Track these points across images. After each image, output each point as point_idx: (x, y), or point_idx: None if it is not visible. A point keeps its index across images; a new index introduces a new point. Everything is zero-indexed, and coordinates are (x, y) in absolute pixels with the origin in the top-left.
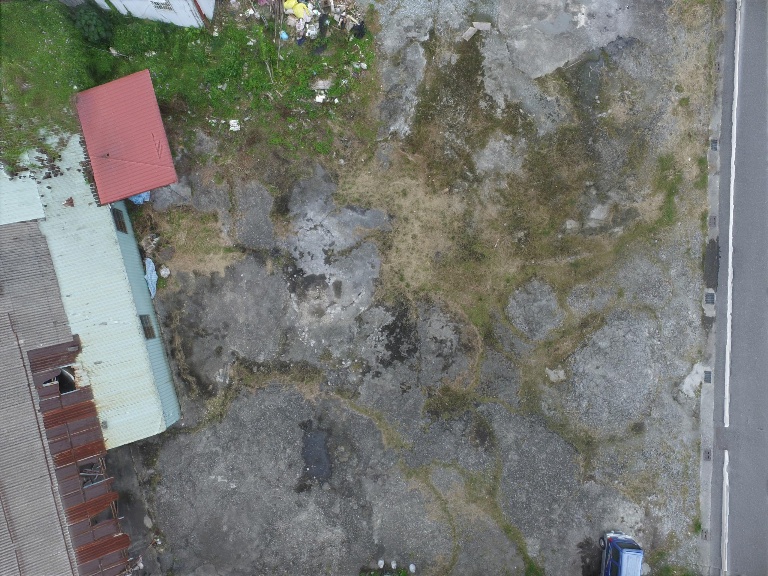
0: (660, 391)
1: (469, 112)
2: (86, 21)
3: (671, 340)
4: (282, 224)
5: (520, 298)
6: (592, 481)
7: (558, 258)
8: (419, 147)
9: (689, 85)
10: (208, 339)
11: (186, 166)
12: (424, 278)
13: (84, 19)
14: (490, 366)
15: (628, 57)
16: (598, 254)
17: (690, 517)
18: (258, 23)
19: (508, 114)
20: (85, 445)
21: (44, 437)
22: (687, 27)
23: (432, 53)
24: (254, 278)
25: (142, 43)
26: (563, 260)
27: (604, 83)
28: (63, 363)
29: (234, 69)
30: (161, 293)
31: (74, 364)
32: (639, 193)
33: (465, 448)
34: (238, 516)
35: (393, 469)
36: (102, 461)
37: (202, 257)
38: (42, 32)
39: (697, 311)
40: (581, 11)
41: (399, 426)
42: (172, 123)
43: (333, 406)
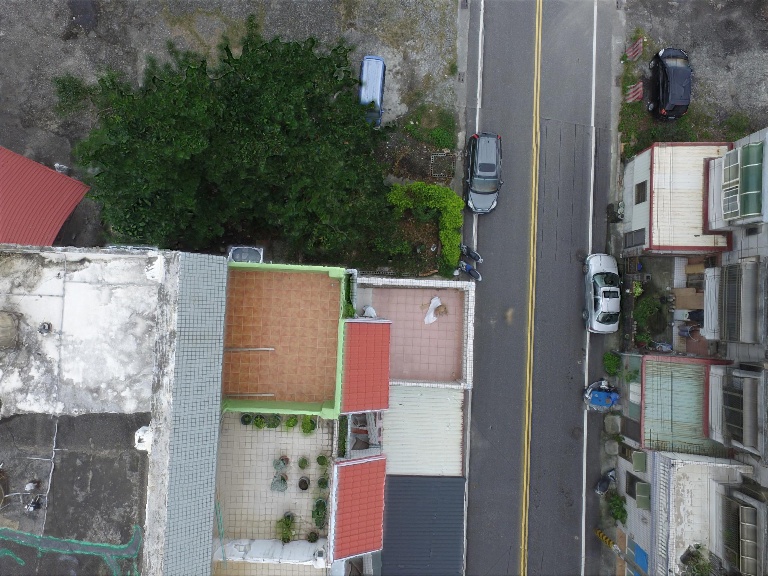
0: None
1: None
2: None
3: None
4: None
5: None
6: (352, 28)
7: None
8: None
9: None
10: None
11: None
12: None
13: None
14: None
15: None
16: None
17: (447, 61)
18: None
19: None
20: None
21: None
22: None
23: None
24: None
25: None
26: None
27: None
28: None
29: None
30: None
31: None
32: None
33: None
34: (6, 62)
35: (157, 18)
36: None
37: None
38: None
39: None
40: None
41: None
42: None
43: None
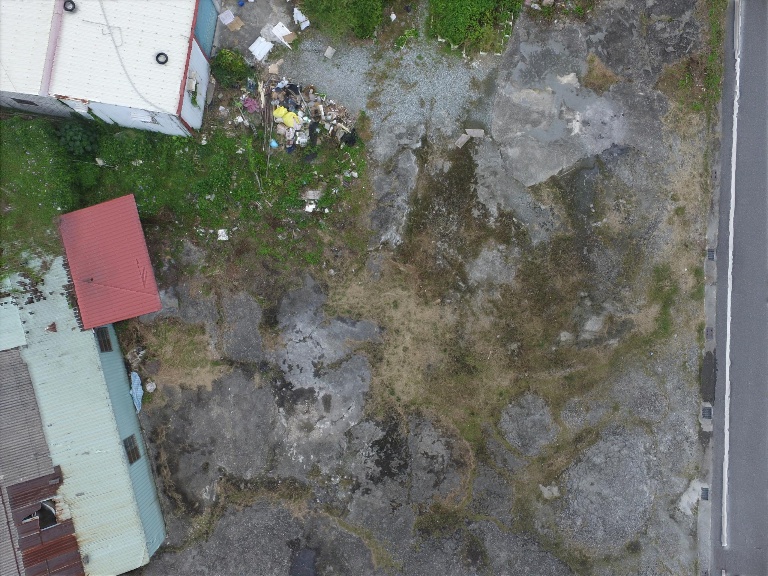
0: (656, 508)
1: (462, 221)
2: (71, 137)
3: (667, 456)
4: (271, 336)
5: (513, 412)
6: None
7: (552, 371)
8: (411, 257)
9: (685, 194)
10: (194, 455)
11: (173, 276)
12: (415, 392)
13: (69, 135)
14: (482, 482)
15: (623, 165)
16: (593, 367)
17: None
18: (247, 131)
19: (501, 223)
20: None
21: None
22: (683, 134)
23: (424, 161)
24: (242, 392)
25: (129, 154)
26: (557, 373)
27: (599, 191)
28: (44, 497)
29: (222, 180)
30: (147, 408)
31: (55, 497)
32: (635, 304)
33: (457, 568)
34: None
35: None
36: None
37: (189, 370)
38: (26, 153)
39: (694, 426)
40: (576, 118)
41: (389, 545)
42: (159, 233)
43: (322, 524)
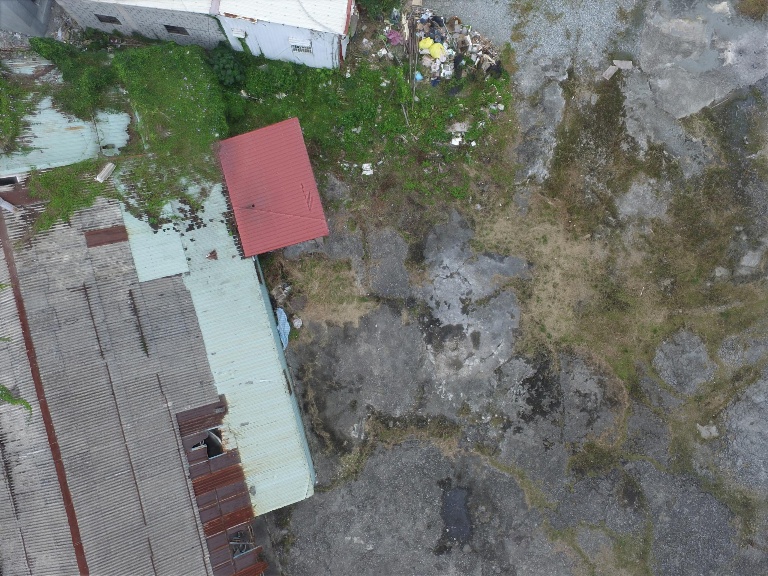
0: None
1: (610, 154)
2: (224, 65)
3: None
4: (417, 272)
5: (668, 350)
6: (748, 545)
7: (707, 307)
8: (559, 191)
9: None
10: (342, 392)
11: None
12: (566, 328)
13: (222, 63)
14: (637, 422)
15: None
16: (749, 303)
17: None
18: (392, 63)
19: (652, 156)
20: (234, 512)
21: (195, 505)
22: None
23: (571, 93)
24: (389, 328)
25: (275, 86)
26: (712, 309)
27: (752, 123)
28: (210, 425)
29: (370, 112)
30: (293, 344)
31: (221, 426)
32: None
33: (613, 509)
34: None
35: (537, 531)
36: (250, 528)
37: (335, 307)
38: (184, 78)
39: None
40: (727, 48)
41: (543, 485)
42: None
43: (473, 463)
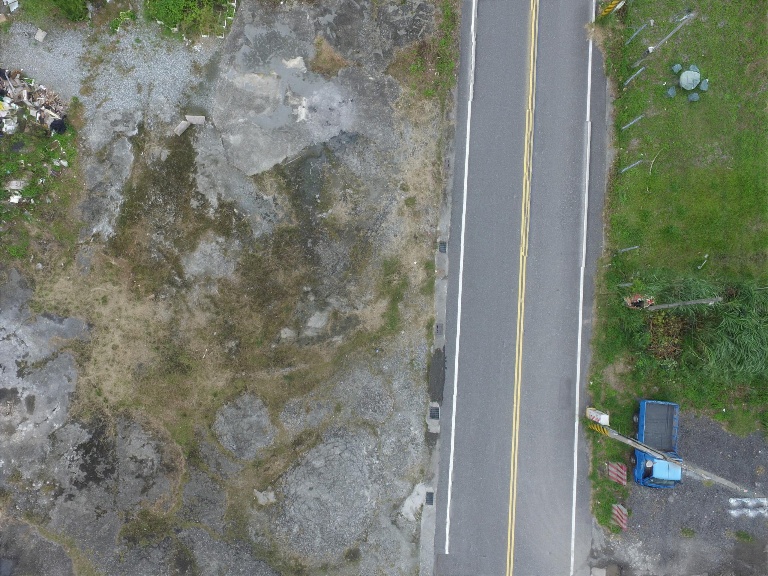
0: (377, 514)
1: (180, 212)
2: None
3: (390, 459)
4: None
5: (229, 413)
6: None
7: (271, 370)
8: (124, 250)
9: (415, 183)
10: None
11: None
12: (125, 392)
13: None
14: (194, 488)
15: (351, 153)
16: (314, 365)
17: None
18: None
19: (221, 214)
20: None
21: None
22: (415, 121)
23: (140, 149)
24: None
25: None
26: (276, 372)
27: (325, 181)
28: None
29: None
30: None
31: None
32: (360, 299)
33: None
34: None
35: None
36: None
37: None
38: None
39: (420, 427)
40: (301, 104)
41: (92, 554)
42: None
43: (21, 532)
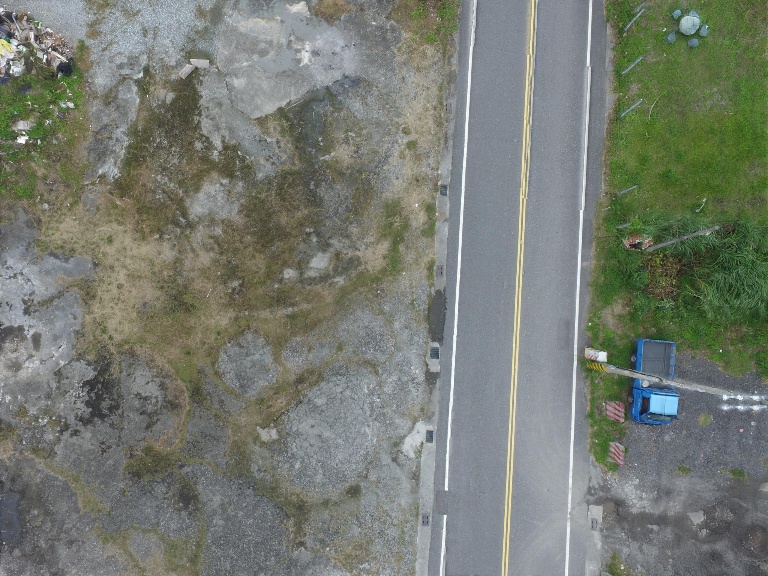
0: (378, 451)
1: (184, 154)
2: None
3: (391, 397)
4: None
5: (232, 352)
6: (302, 548)
7: (273, 309)
8: (129, 191)
9: (417, 127)
10: None
11: None
12: (130, 330)
13: None
14: (197, 424)
15: (354, 97)
16: (316, 305)
17: None
18: None
19: (225, 156)
20: None
21: None
22: (417, 65)
23: (145, 91)
24: None
25: None
26: (279, 311)
27: (328, 124)
28: None
29: None
30: None
31: None
32: (361, 241)
33: (167, 512)
34: None
35: (89, 534)
36: None
37: None
38: None
39: (420, 366)
40: (305, 48)
41: (97, 488)
42: None
43: (27, 467)
